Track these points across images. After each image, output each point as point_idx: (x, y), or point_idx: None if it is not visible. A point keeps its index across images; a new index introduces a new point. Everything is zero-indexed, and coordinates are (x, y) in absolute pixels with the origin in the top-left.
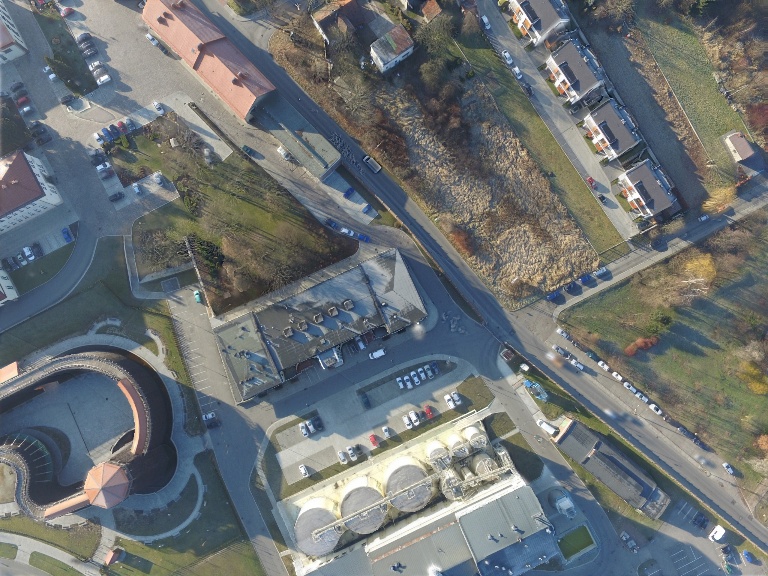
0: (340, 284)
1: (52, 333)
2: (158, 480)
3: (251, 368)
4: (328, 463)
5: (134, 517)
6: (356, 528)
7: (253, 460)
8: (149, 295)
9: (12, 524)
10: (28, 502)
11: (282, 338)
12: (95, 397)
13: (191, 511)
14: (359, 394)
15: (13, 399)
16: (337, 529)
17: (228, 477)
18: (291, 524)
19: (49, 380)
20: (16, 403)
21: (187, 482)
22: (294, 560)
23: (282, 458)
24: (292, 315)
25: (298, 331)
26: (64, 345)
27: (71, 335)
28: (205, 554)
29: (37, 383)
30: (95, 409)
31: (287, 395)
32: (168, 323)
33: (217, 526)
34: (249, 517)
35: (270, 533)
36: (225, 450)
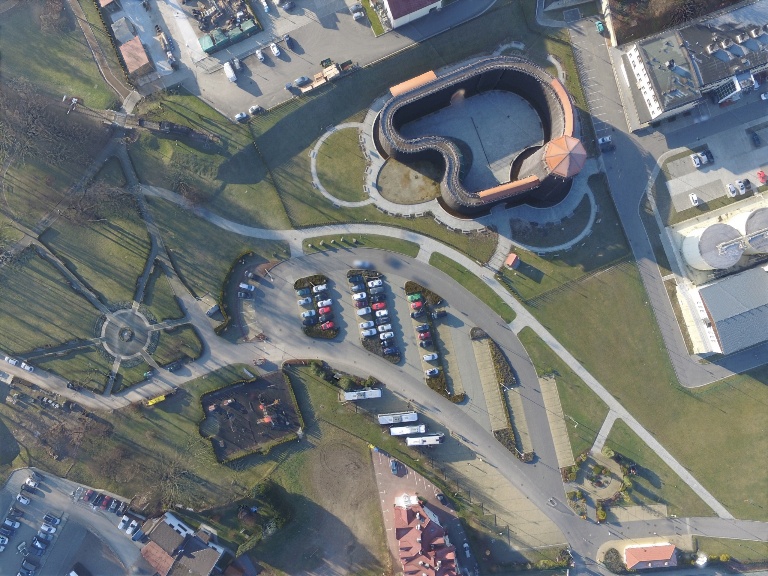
0: (762, 9)
1: (462, 49)
2: (555, 195)
3: (675, 80)
4: (716, 195)
5: (529, 228)
6: (759, 246)
7: (644, 186)
8: (552, 23)
9: (416, 224)
10: (458, 188)
11: (705, 54)
12: (497, 114)
13: (583, 228)
14: (748, 133)
15: (427, 105)
16: (743, 243)
17: (619, 200)
18: (677, 249)
19: (467, 87)
20: (425, 112)
21: (581, 200)
22: (678, 284)
23: (672, 186)
24: (715, 34)
25: (721, 49)
26: (470, 63)
27: (477, 54)
28: (595, 269)
29: (467, 81)
30: (497, 125)
31: (679, 128)
32: (569, 50)
33: (606, 245)
34: (637, 239)
35: (655, 257)
36: (617, 174)
